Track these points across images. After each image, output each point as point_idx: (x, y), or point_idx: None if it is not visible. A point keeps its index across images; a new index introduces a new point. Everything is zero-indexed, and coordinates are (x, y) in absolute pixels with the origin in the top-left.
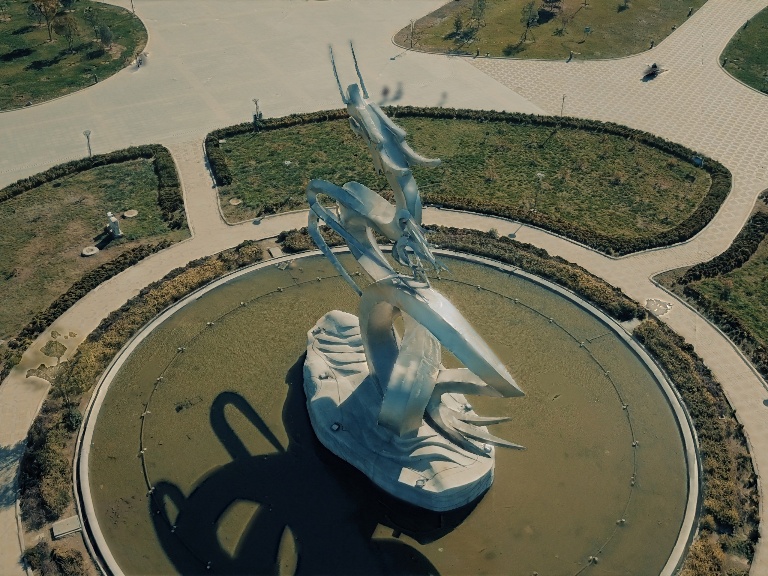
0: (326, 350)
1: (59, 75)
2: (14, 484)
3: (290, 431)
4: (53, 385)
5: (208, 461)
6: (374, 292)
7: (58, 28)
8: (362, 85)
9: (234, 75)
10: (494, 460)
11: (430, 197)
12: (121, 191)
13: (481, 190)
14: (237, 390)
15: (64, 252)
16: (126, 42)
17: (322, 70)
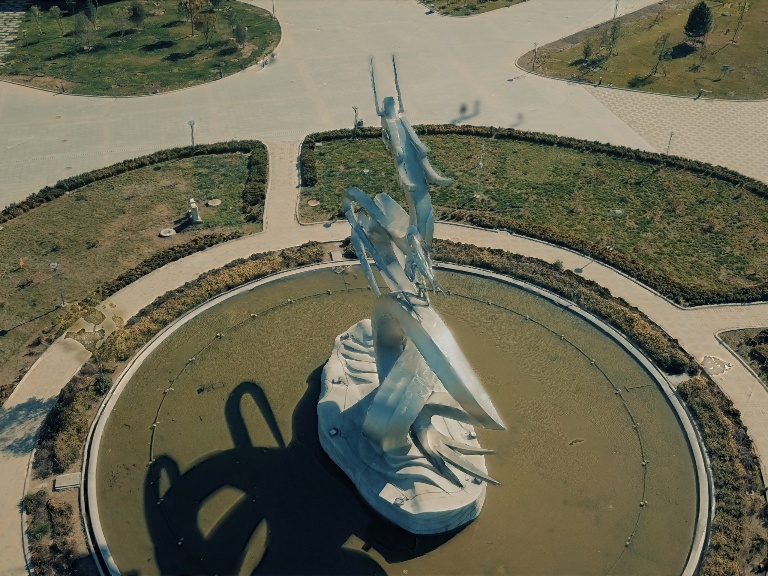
0: (348, 356)
1: (190, 68)
2: (36, 434)
3: (296, 429)
4: (87, 349)
5: (211, 444)
6: (381, 304)
7: (197, 24)
8: (399, 99)
9: (350, 82)
10: (486, 493)
11: (505, 221)
12: (212, 181)
13: (561, 220)
14: (259, 382)
15: (145, 231)
16: (259, 42)
17: (436, 85)
